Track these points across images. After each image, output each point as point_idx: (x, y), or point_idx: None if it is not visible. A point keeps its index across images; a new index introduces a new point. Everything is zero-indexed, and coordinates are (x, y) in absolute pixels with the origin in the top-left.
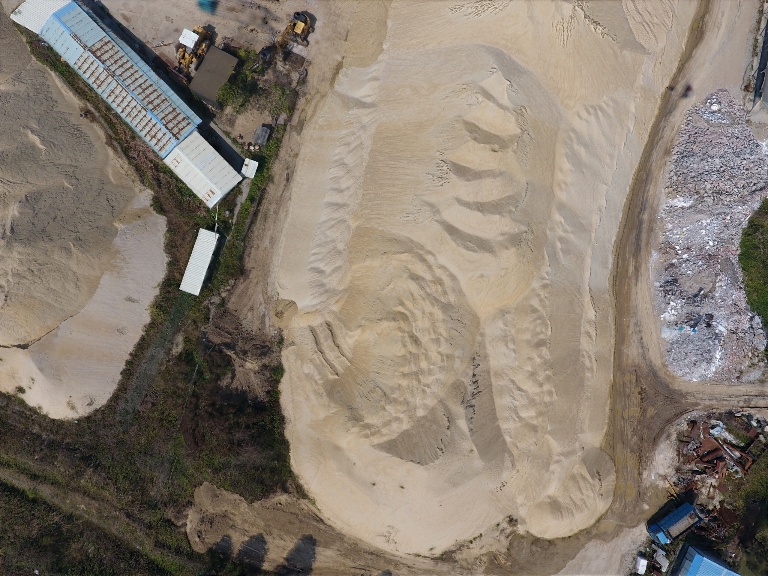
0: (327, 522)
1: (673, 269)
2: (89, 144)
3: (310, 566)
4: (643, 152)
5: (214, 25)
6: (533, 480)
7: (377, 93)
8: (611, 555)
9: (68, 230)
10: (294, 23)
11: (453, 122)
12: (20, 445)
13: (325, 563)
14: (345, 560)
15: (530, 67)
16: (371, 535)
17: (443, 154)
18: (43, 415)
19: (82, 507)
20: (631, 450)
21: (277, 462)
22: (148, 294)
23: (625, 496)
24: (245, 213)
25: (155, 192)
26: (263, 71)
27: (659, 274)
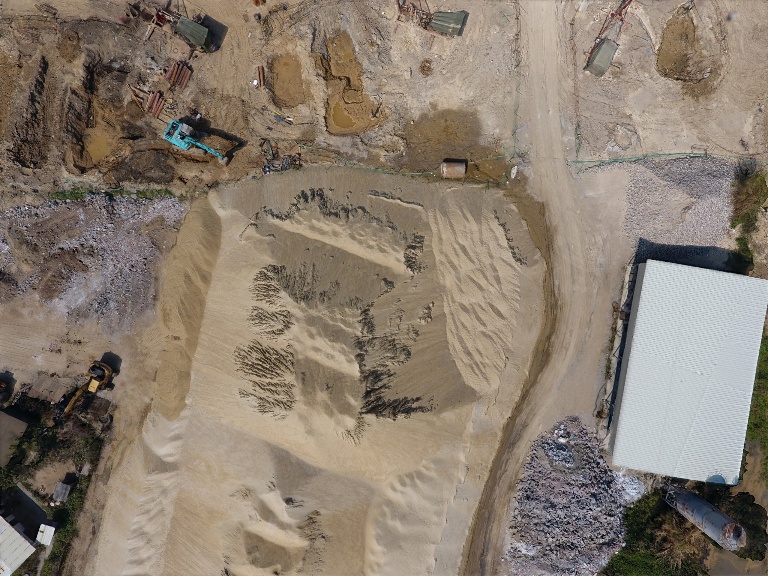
0: None
1: None
2: None
3: None
4: (484, 489)
5: (12, 371)
6: None
7: (180, 452)
8: None
9: None
10: (91, 376)
11: (236, 530)
12: None
13: None
14: None
15: (322, 465)
16: None
17: (227, 563)
18: None
19: None
20: None
21: None
22: None
23: None
24: (48, 572)
25: None
26: (61, 424)
27: None
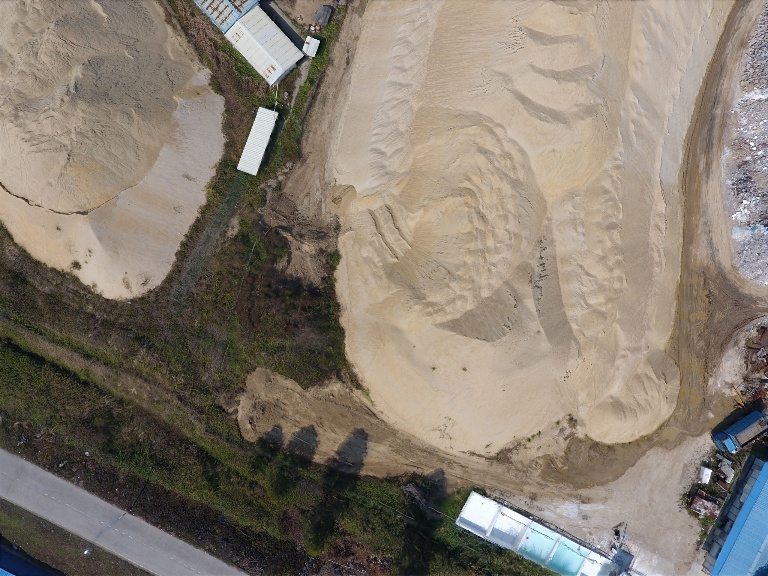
0: (380, 416)
1: (747, 166)
2: (149, 19)
3: (361, 461)
4: (718, 43)
5: None
6: (597, 374)
7: None
8: (673, 464)
9: (130, 97)
10: None
11: None
12: (74, 323)
13: (376, 458)
14: (397, 456)
15: None
16: (425, 430)
17: (517, 20)
18: (97, 294)
19: (133, 391)
20: (697, 355)
21: (332, 348)
22: (205, 174)
23: (689, 403)
24: (304, 96)
25: (214, 72)
26: None
27: (732, 172)
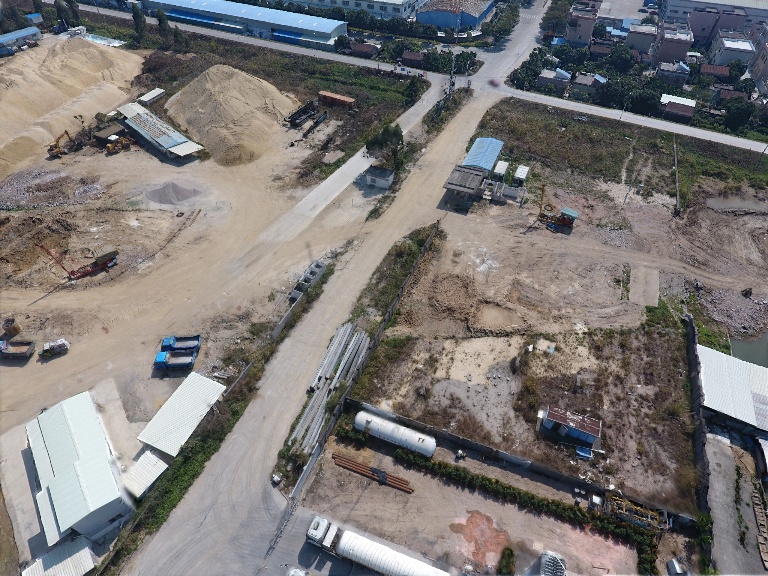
0: None
1: None
2: None
3: None
4: None
5: None
6: None
7: None
8: None
9: None
10: None
11: None
12: (248, 67)
13: None
14: None
15: None
16: None
17: (6, 87)
18: None
19: None
20: None
21: None
22: None
23: None
24: None
25: None
26: None
27: None
